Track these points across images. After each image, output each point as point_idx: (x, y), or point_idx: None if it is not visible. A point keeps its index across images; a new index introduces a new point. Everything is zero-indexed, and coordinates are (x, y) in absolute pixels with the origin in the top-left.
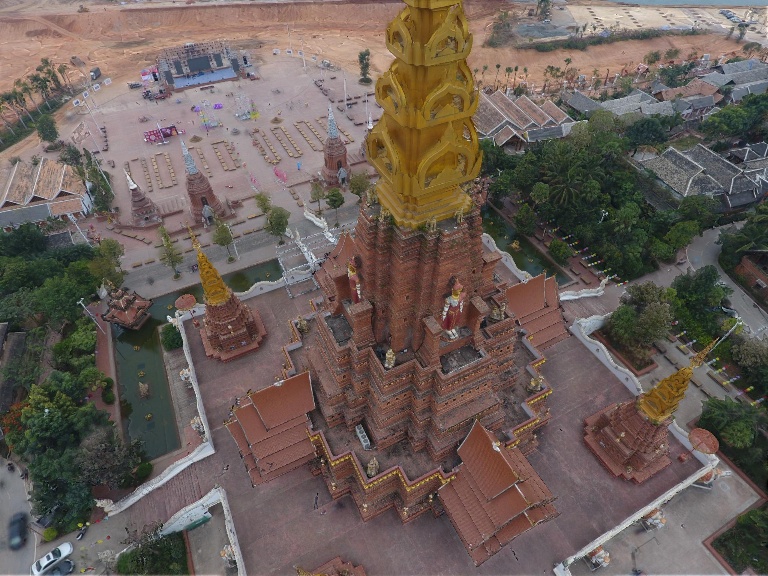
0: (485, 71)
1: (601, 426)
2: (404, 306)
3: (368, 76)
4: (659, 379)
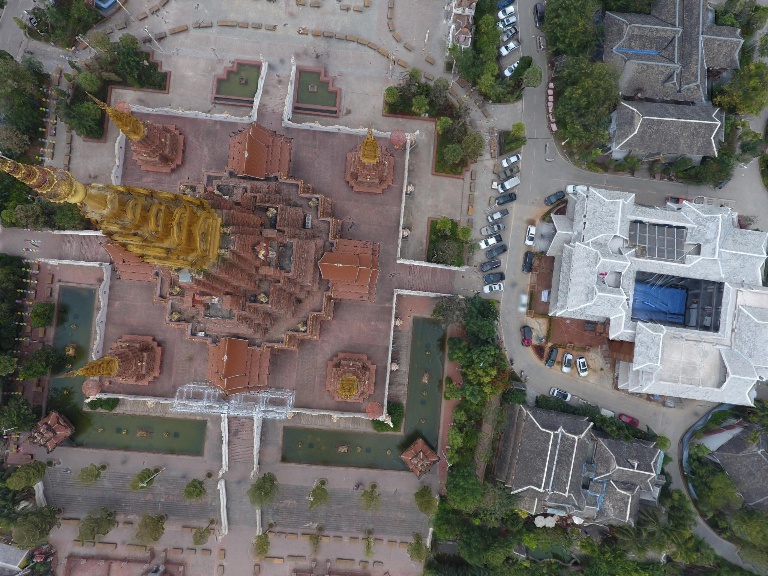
0: None
1: (165, 161)
2: None
3: None
4: (88, 177)
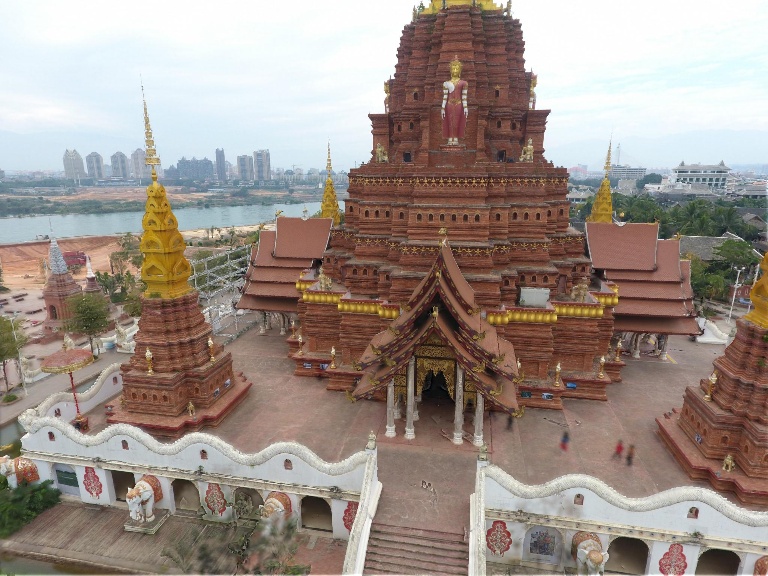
0: None
1: None
2: None
3: (2, 284)
4: None
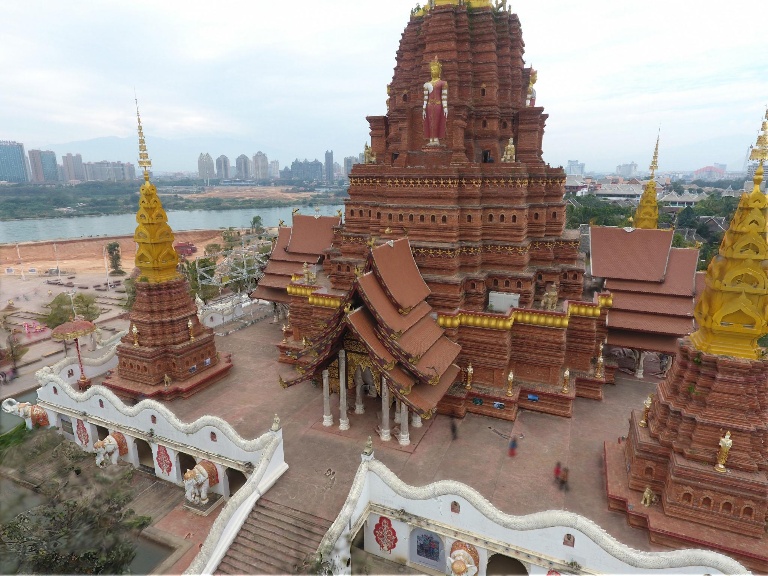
0: (249, 243)
1: None
2: (497, 102)
3: (120, 268)
4: None
